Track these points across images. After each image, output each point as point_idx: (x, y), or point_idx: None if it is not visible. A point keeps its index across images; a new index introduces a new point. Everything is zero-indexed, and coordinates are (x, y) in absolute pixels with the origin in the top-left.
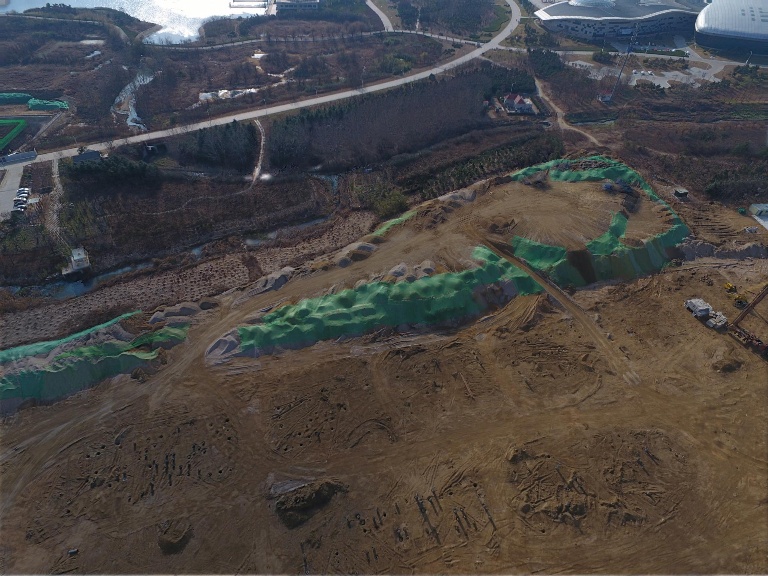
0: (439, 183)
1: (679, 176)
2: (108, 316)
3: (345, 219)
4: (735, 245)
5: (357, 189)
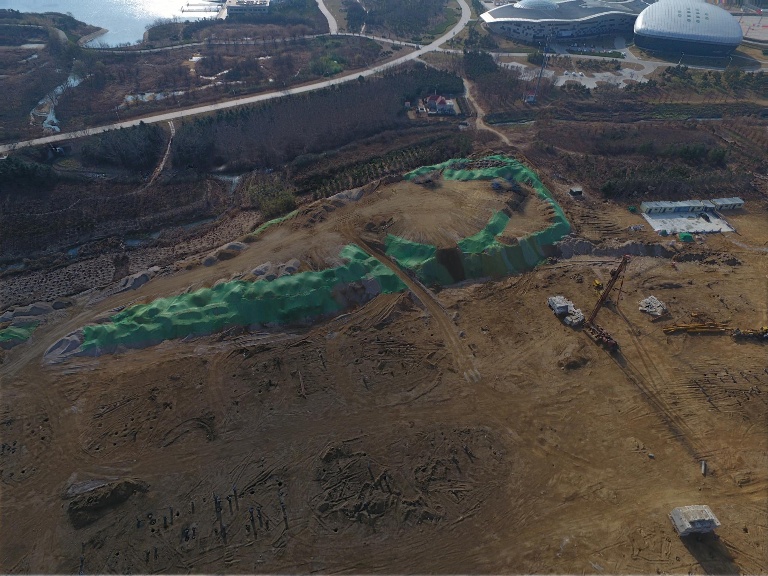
0: (334, 183)
1: (579, 175)
2: None
3: (232, 219)
4: (614, 243)
5: (251, 189)
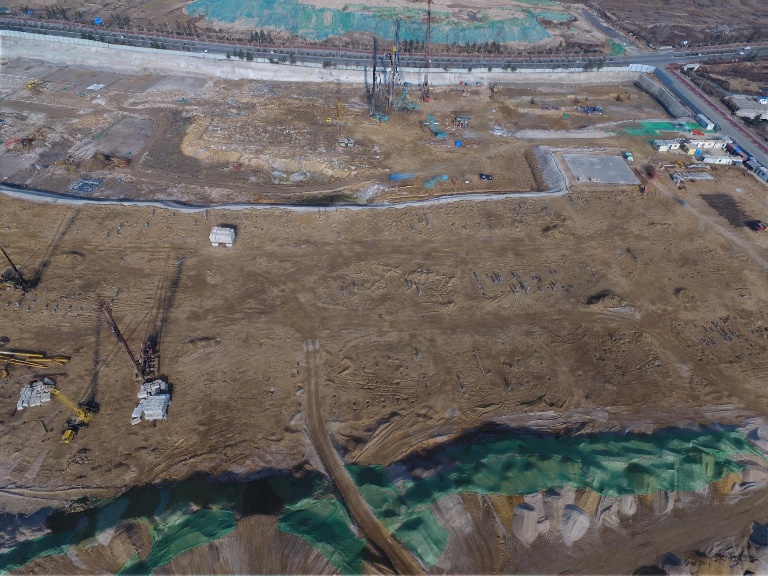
0: None
1: None
2: None
3: None
4: None
5: None
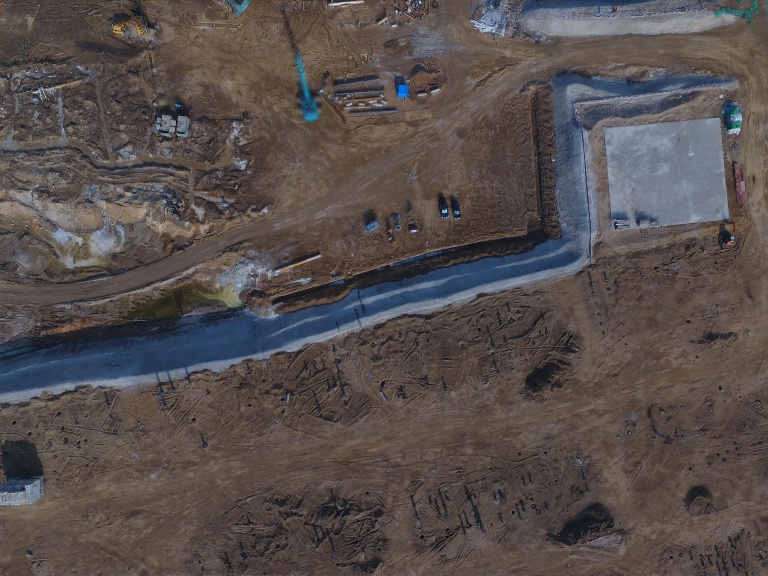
0: None
1: None
2: None
3: None
4: None
5: None
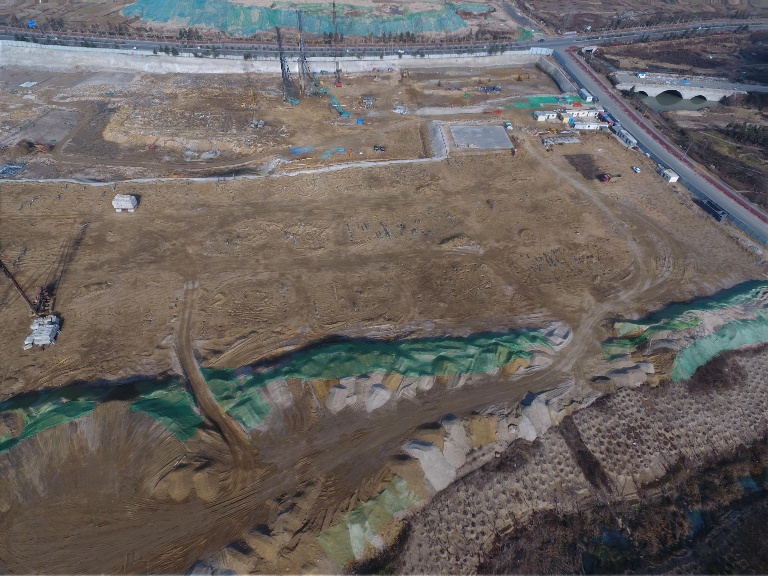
0: None
1: None
2: (704, 376)
3: None
4: None
5: None
